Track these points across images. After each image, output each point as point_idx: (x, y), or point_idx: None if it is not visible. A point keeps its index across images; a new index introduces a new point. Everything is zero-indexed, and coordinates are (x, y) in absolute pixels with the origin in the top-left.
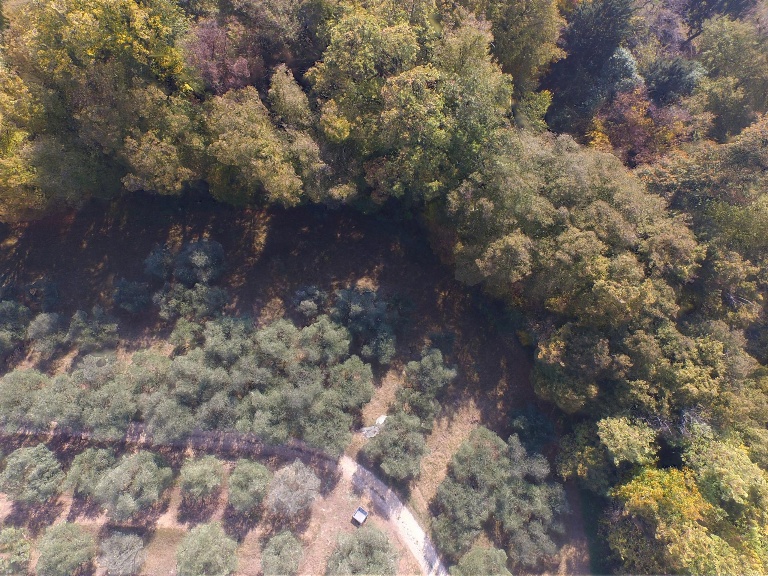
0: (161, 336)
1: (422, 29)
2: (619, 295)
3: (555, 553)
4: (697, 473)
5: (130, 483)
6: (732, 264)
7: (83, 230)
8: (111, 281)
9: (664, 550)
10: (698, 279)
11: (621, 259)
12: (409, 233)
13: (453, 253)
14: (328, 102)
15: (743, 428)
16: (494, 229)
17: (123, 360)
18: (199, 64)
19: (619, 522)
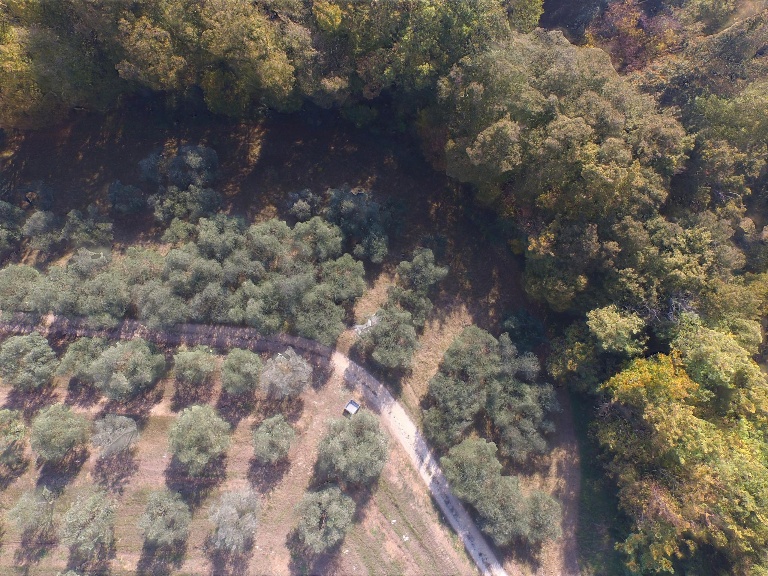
0: (156, 240)
1: None
2: (607, 176)
3: (545, 450)
4: (685, 357)
5: (123, 363)
6: (719, 149)
7: (79, 143)
8: (106, 190)
9: (652, 437)
10: (687, 177)
11: (609, 141)
12: (402, 146)
13: (445, 158)
14: None
15: (731, 320)
16: (484, 117)
17: (118, 262)
18: None
19: (609, 419)
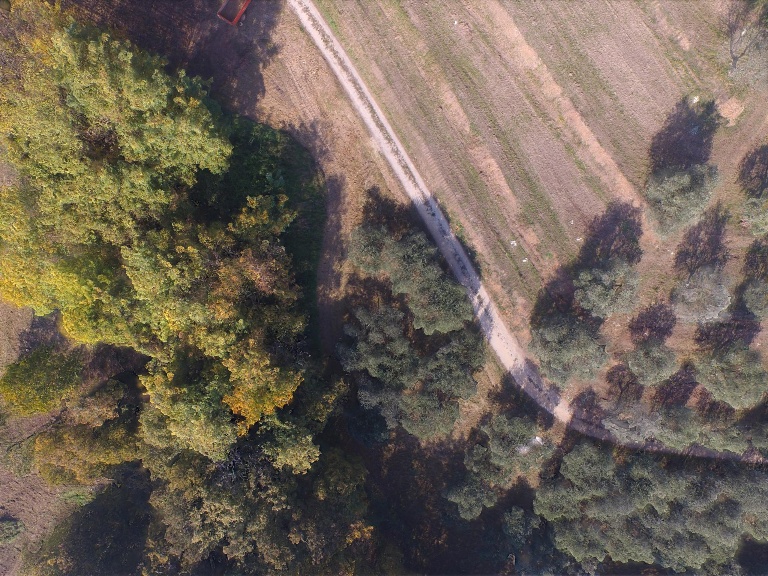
0: None
1: None
2: None
3: (357, 309)
4: None
5: None
6: None
7: None
8: None
9: None
10: None
11: None
12: None
13: None
14: None
15: None
16: None
17: None
18: None
19: None
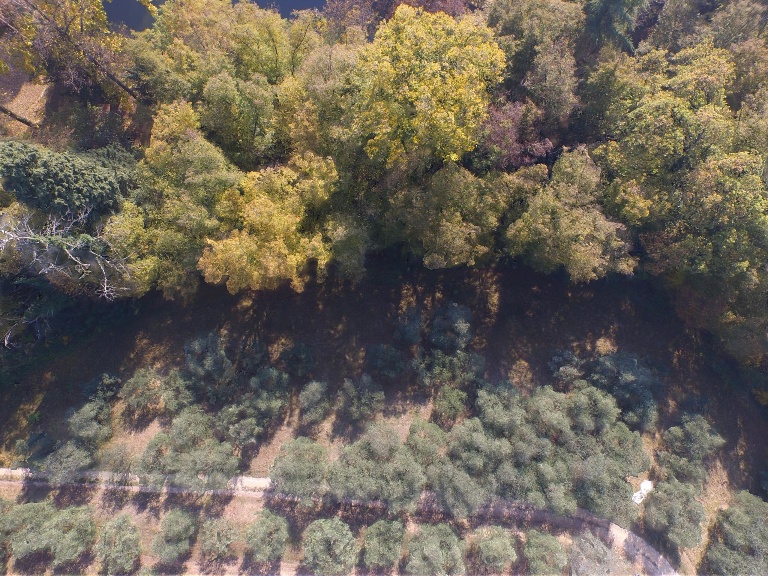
0: (415, 400)
1: (719, 109)
2: None
3: None
4: None
5: None
6: None
7: (315, 290)
8: (354, 343)
9: None
10: None
11: None
12: (638, 292)
13: (703, 317)
14: (629, 182)
15: None
16: None
17: (383, 425)
18: (510, 147)
19: None
